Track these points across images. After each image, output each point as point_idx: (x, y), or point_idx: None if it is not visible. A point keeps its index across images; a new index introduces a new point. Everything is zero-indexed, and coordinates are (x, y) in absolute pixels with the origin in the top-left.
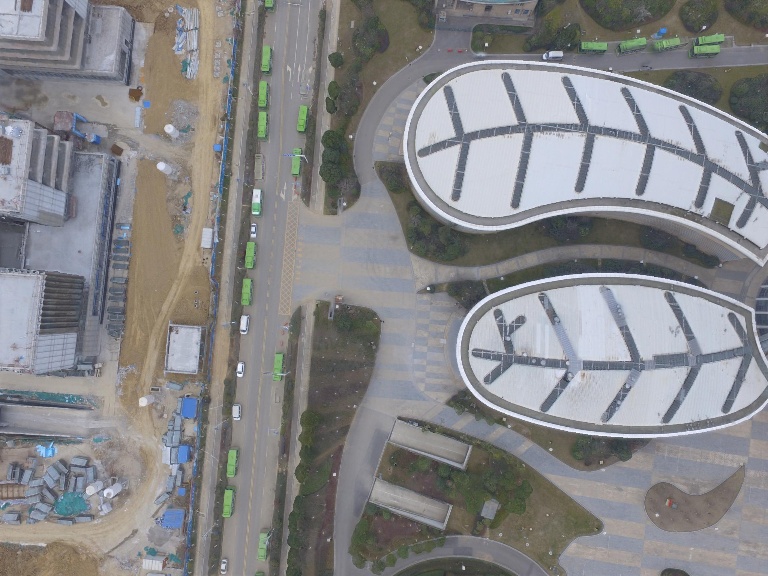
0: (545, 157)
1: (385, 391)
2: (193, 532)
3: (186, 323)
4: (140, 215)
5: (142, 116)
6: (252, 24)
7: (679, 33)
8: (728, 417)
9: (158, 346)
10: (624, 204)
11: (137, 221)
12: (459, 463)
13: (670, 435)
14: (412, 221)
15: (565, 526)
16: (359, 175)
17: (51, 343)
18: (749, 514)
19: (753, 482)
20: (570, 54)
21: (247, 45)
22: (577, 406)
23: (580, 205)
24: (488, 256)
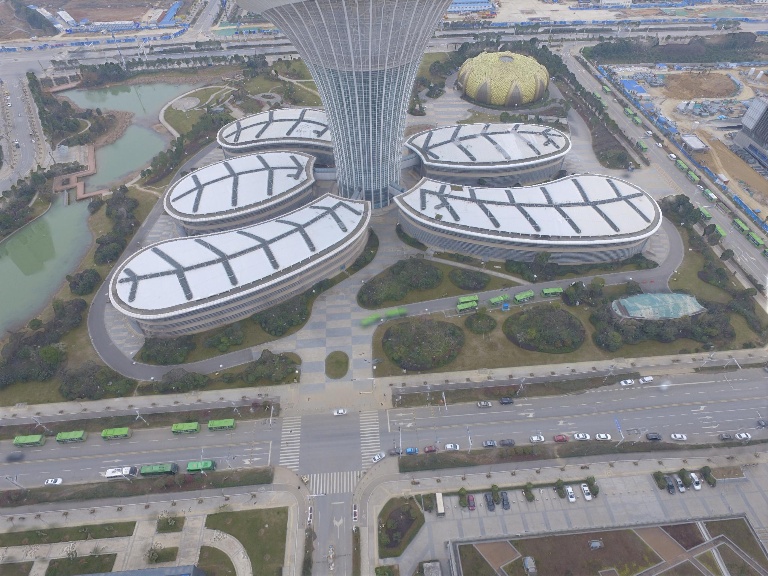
0: None
1: (583, 146)
2: (636, 106)
3: None
4: None
5: None
6: None
7: None
8: None
9: None
10: None
11: (767, 183)
12: None
13: None
14: None
15: (474, 121)
16: None
17: (759, 112)
18: None
19: None
20: None
21: None
22: None
23: None
24: None
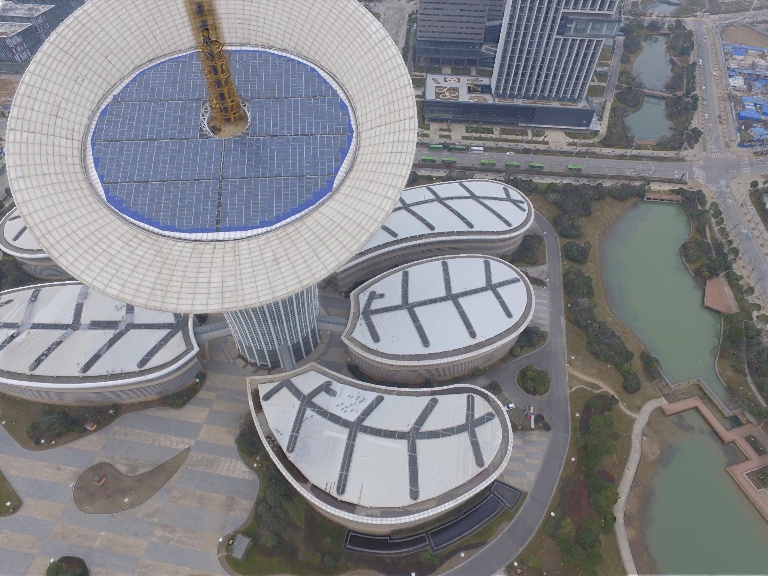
0: None
1: None
2: None
3: None
4: None
5: None
6: None
7: None
8: (143, 373)
9: None
10: None
11: None
12: None
13: (86, 385)
14: None
15: None
16: None
17: None
18: (177, 496)
19: (192, 463)
20: None
21: None
22: (13, 357)
23: None
24: None
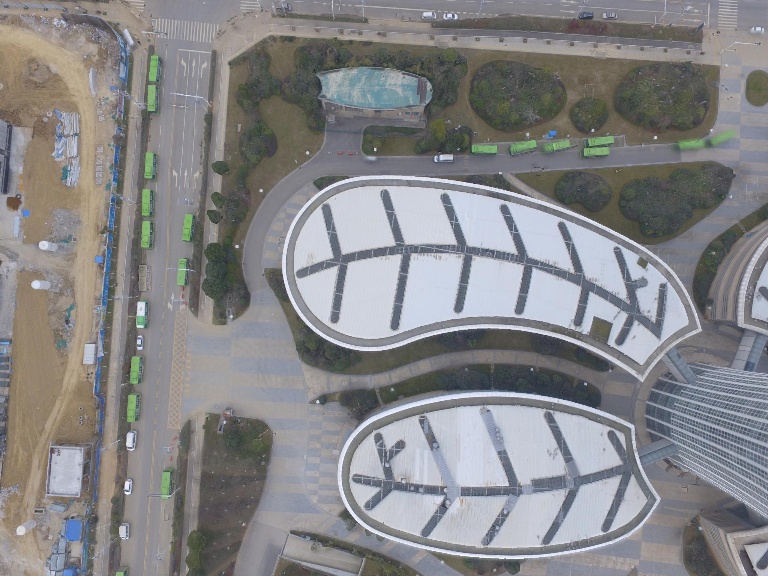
0: (423, 279)
1: (277, 505)
2: None
3: (71, 441)
4: (20, 330)
5: (21, 226)
6: (136, 127)
7: (570, 133)
8: (608, 535)
9: (42, 465)
10: (505, 322)
11: (17, 336)
12: (355, 573)
13: (551, 555)
14: (299, 334)
15: None
16: (249, 283)
17: None
18: None
19: None
20: (462, 155)
21: (131, 149)
22: (457, 531)
23: (461, 324)
24: (380, 364)
